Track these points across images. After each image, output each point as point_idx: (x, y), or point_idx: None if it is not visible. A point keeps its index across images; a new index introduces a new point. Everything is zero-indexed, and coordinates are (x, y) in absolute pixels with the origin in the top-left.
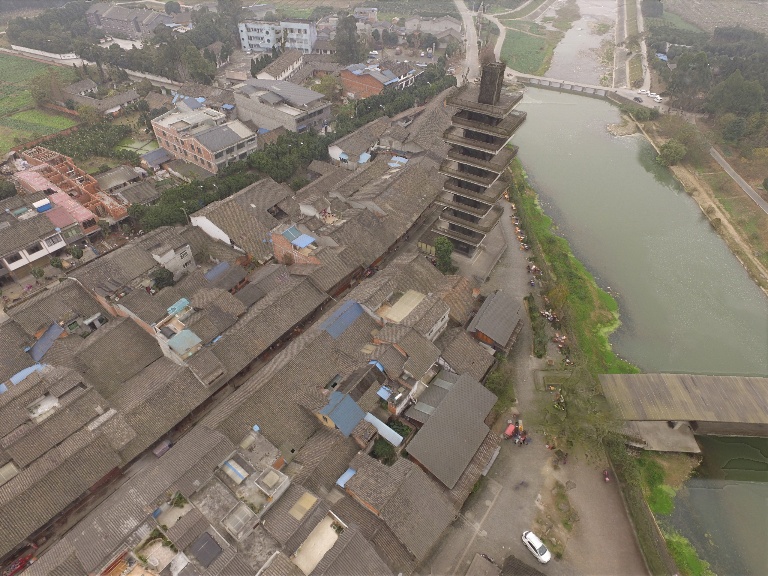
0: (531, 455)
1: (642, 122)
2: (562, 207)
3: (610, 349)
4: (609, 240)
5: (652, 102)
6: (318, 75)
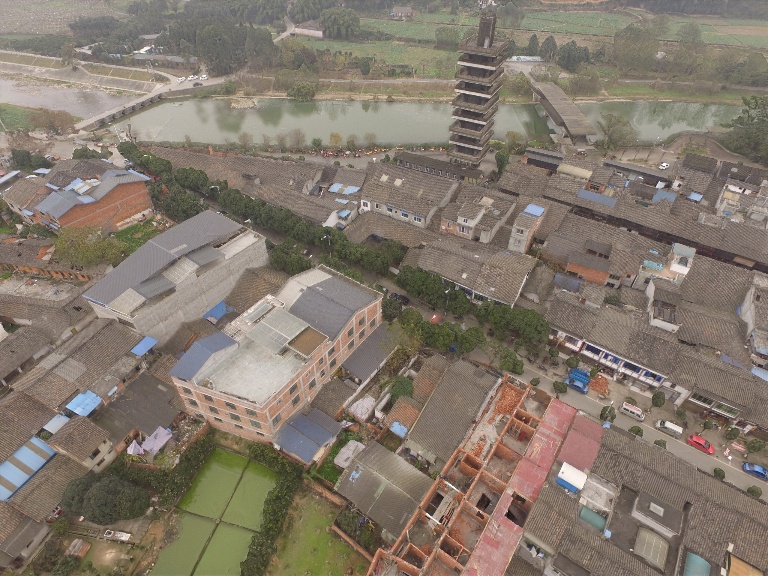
0: None
1: (234, 94)
2: (373, 141)
3: None
4: None
5: (204, 81)
6: None
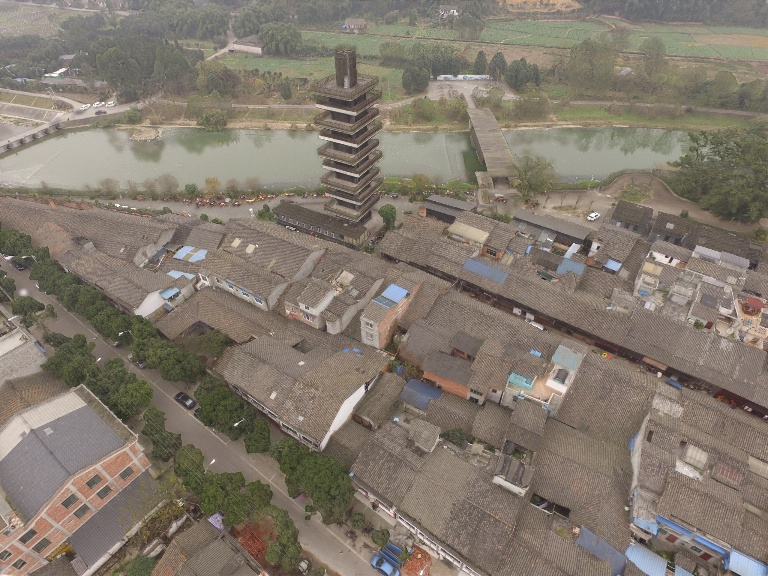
0: (541, 214)
1: (140, 122)
2: (272, 181)
3: (439, 186)
4: None
5: (110, 109)
6: None
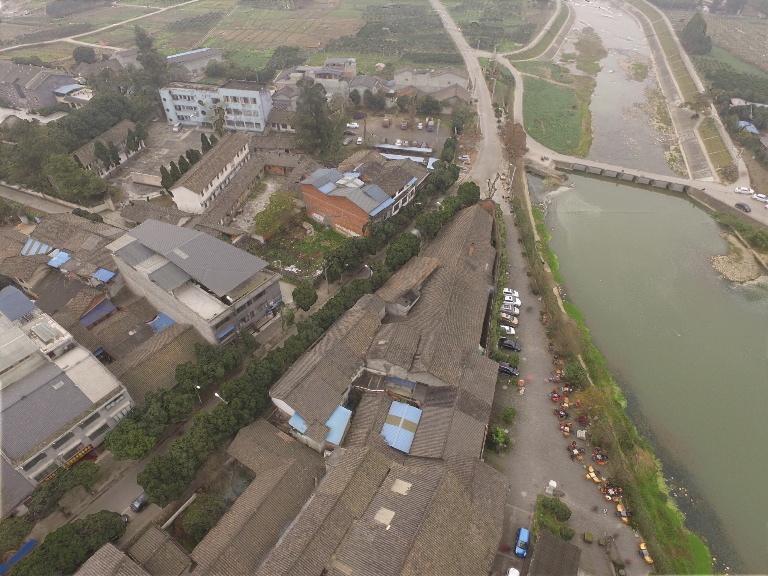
0: None
1: (762, 251)
2: (713, 499)
3: None
4: None
5: (764, 211)
6: (272, 171)
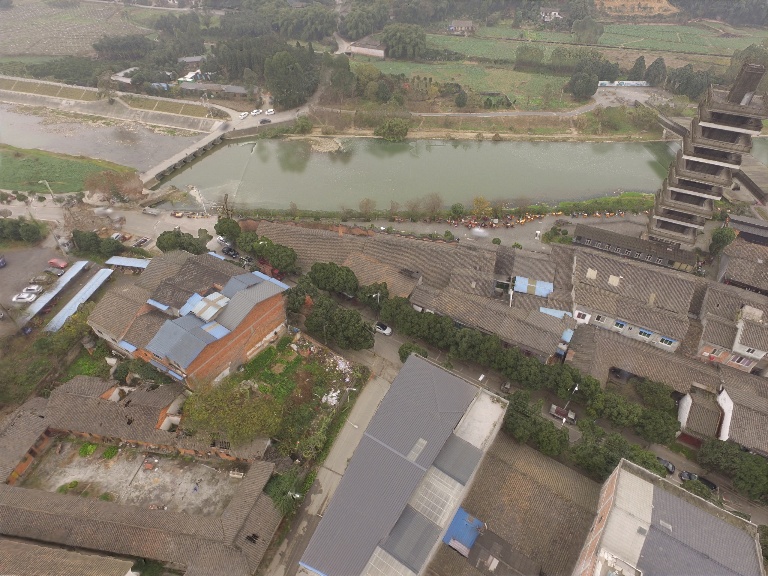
0: None
1: (310, 132)
2: (505, 198)
3: None
4: (547, 183)
5: (271, 117)
6: (12, 483)
